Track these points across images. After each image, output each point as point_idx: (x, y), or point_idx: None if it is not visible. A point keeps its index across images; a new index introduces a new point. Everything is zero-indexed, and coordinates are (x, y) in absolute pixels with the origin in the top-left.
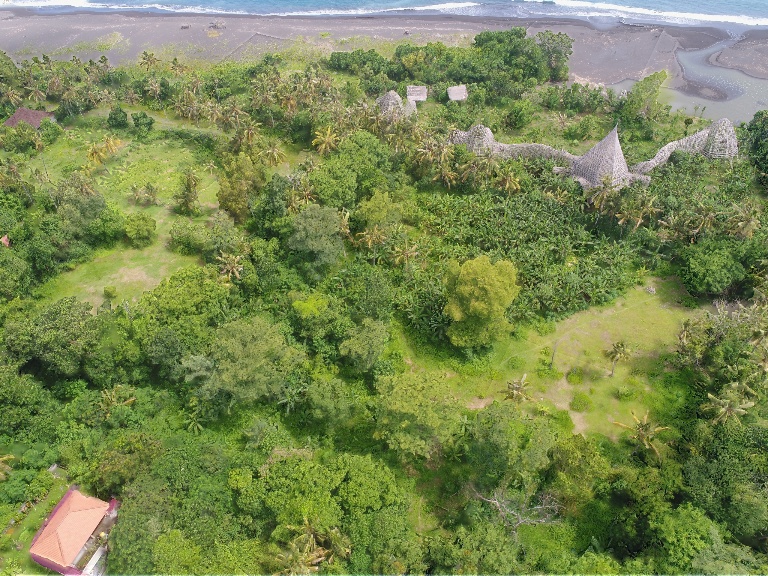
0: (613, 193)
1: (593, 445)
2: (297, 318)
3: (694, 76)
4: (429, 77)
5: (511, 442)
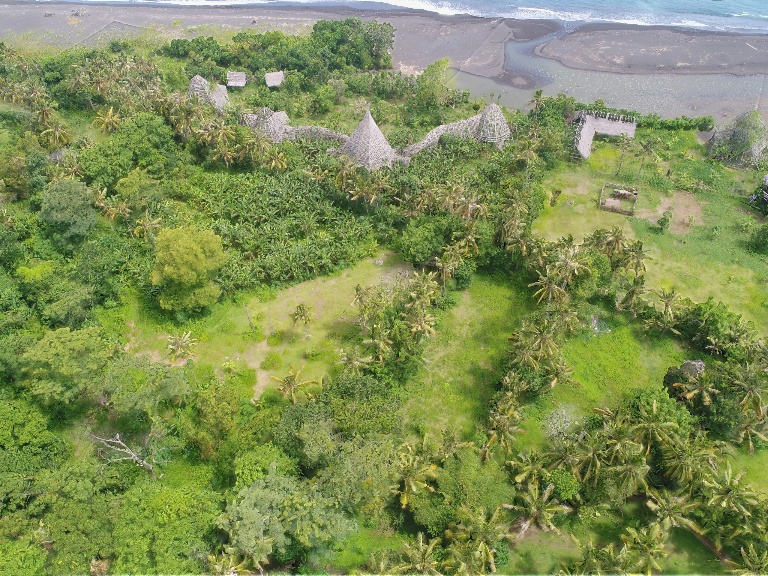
0: (351, 171)
1: (230, 394)
2: (22, 283)
3: (513, 65)
4: (257, 64)
5: (119, 386)
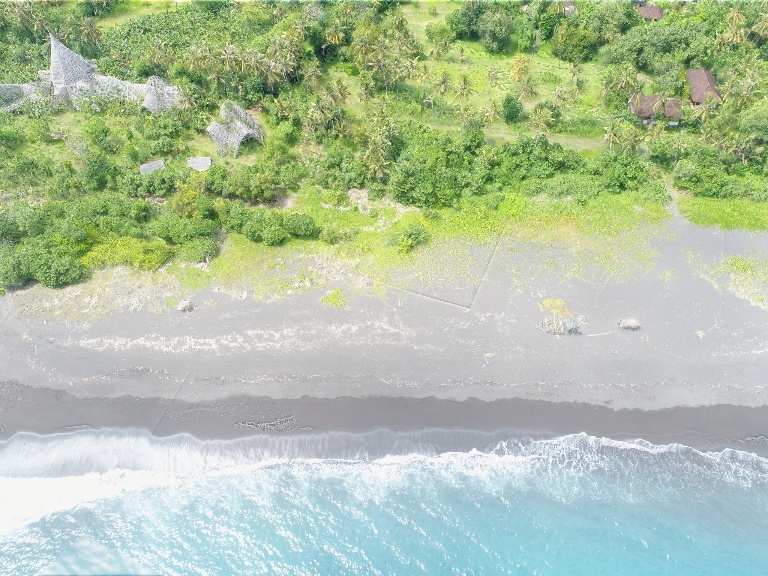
0: None
1: None
2: None
3: None
4: None
5: None
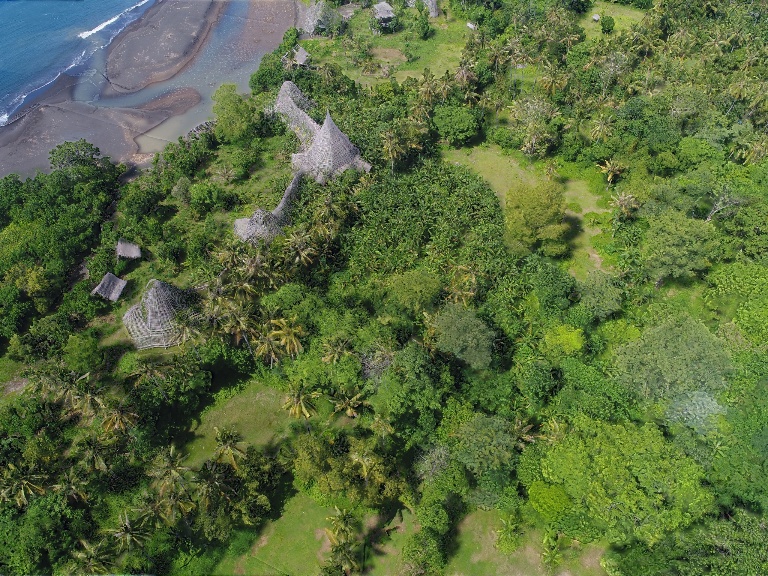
0: None
1: None
2: None
3: (150, 105)
4: None
5: (700, 184)
